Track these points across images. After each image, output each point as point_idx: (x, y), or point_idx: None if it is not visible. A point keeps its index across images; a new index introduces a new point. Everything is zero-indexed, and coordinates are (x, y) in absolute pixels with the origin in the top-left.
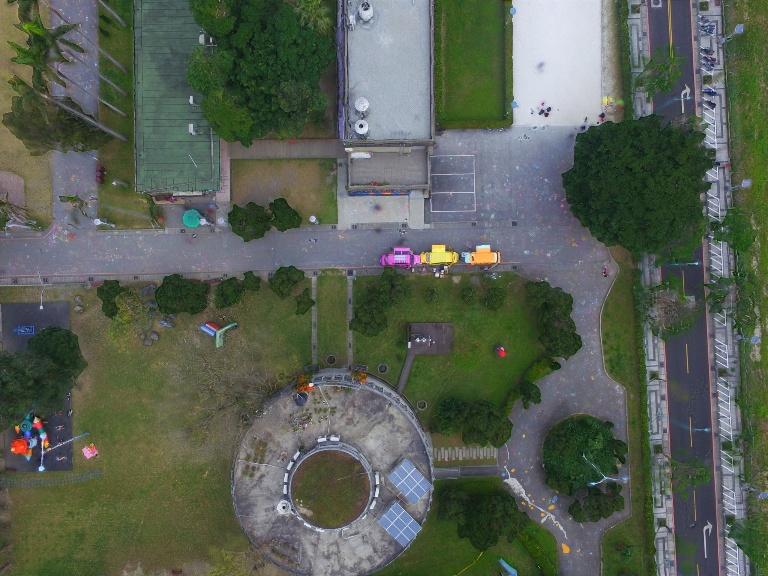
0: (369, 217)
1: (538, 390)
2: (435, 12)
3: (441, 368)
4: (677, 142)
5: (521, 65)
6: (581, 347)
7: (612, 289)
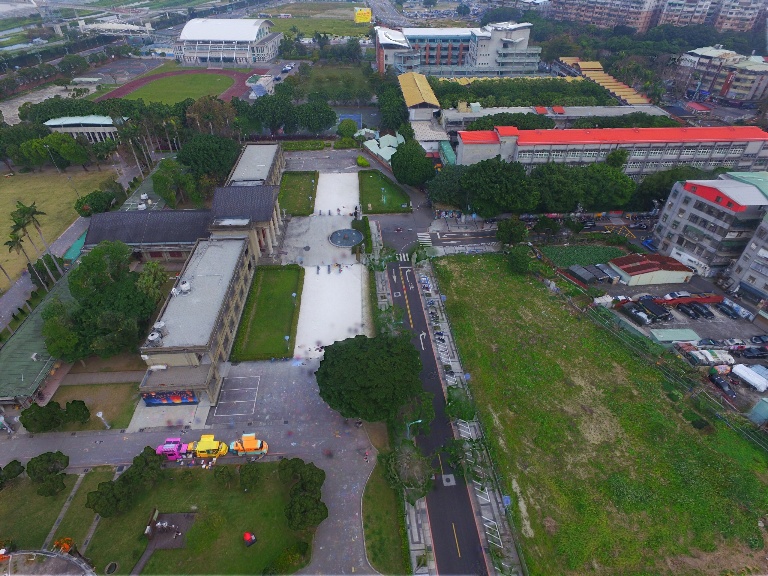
0: (158, 422)
1: (275, 571)
2: (249, 302)
3: (179, 565)
4: (393, 343)
5: (305, 326)
6: (341, 533)
7: (373, 472)
